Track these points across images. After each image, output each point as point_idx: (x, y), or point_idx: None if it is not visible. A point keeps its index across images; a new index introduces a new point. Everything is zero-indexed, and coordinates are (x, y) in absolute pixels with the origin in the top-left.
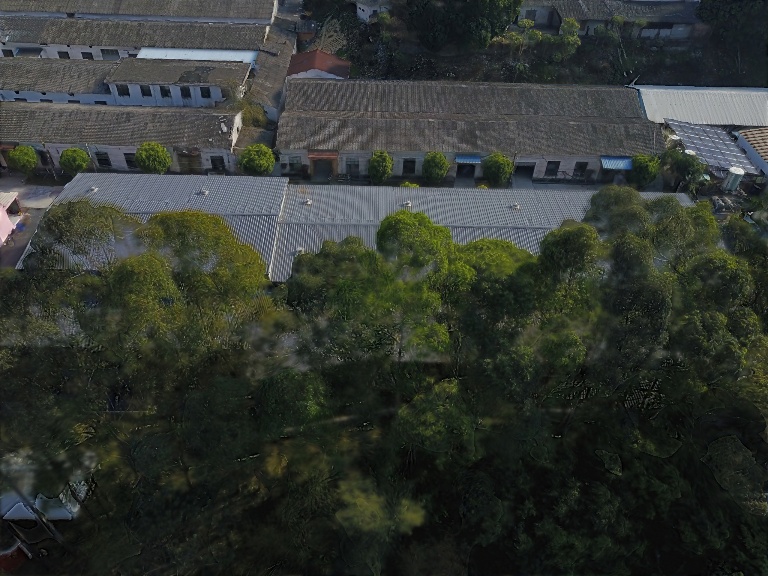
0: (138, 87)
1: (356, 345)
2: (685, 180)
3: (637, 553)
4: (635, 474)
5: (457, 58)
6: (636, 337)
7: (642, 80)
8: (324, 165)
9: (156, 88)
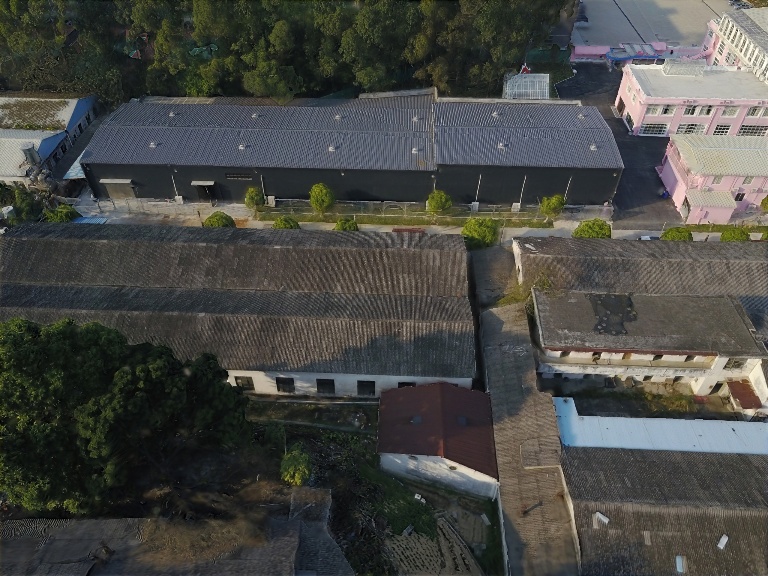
0: None
1: None
2: None
3: None
4: None
5: None
6: None
7: None
8: None
9: None
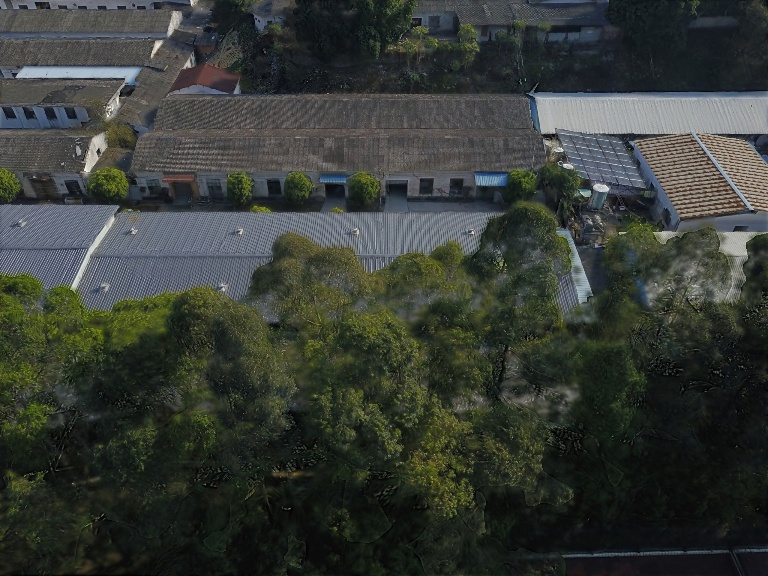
0: (0, 109)
1: None
2: (564, 196)
3: None
4: (357, 556)
5: (352, 69)
6: (246, 423)
7: (548, 87)
8: (185, 187)
9: (19, 110)
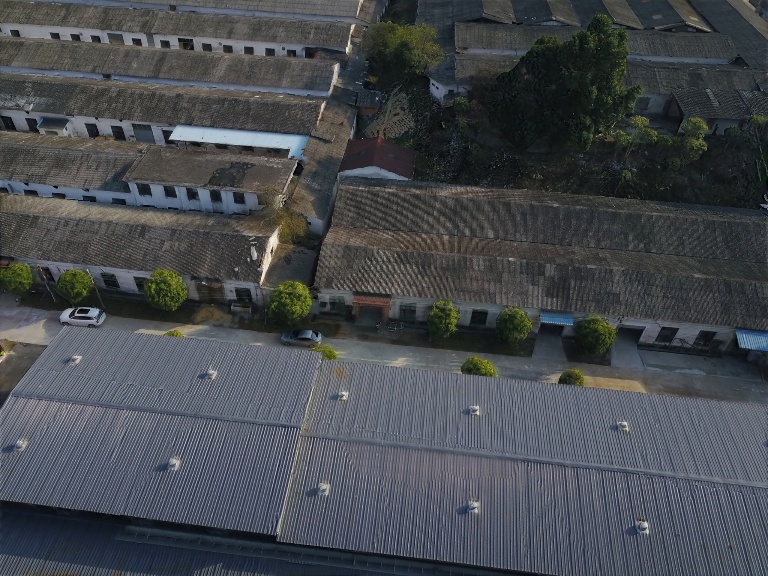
0: (161, 187)
1: None
2: None
3: None
4: None
5: (547, 156)
6: None
7: None
8: (372, 307)
9: (182, 190)
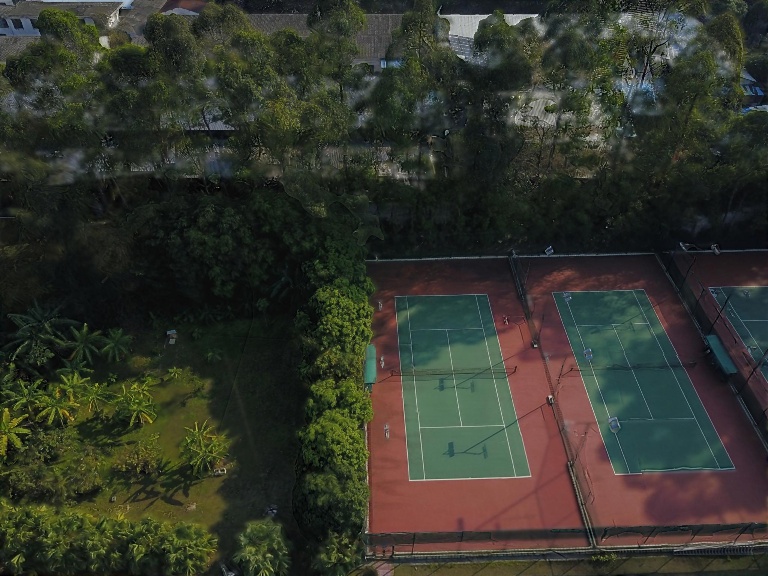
0: (29, 21)
1: (42, 98)
2: None
3: (267, 260)
4: (254, 202)
5: None
6: (181, 74)
7: (454, 12)
8: None
9: None
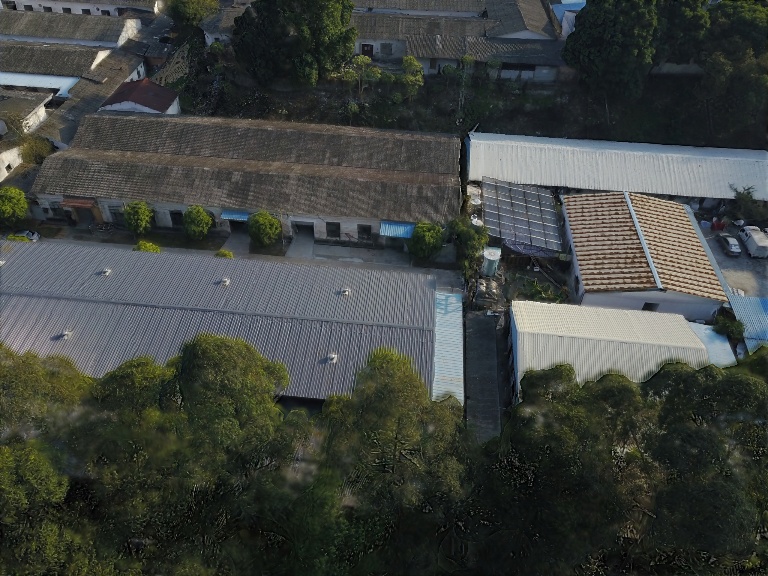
0: None
1: None
2: None
3: None
4: None
5: (293, 94)
6: None
7: (495, 127)
8: (88, 212)
9: None
